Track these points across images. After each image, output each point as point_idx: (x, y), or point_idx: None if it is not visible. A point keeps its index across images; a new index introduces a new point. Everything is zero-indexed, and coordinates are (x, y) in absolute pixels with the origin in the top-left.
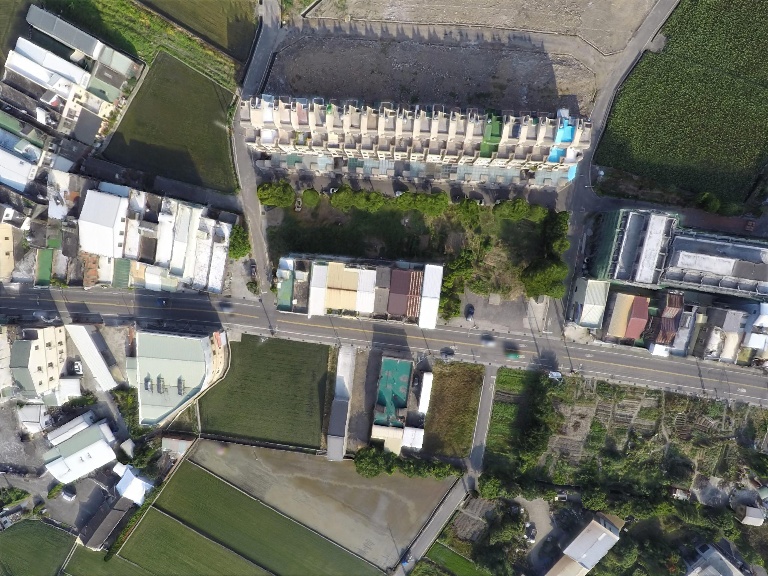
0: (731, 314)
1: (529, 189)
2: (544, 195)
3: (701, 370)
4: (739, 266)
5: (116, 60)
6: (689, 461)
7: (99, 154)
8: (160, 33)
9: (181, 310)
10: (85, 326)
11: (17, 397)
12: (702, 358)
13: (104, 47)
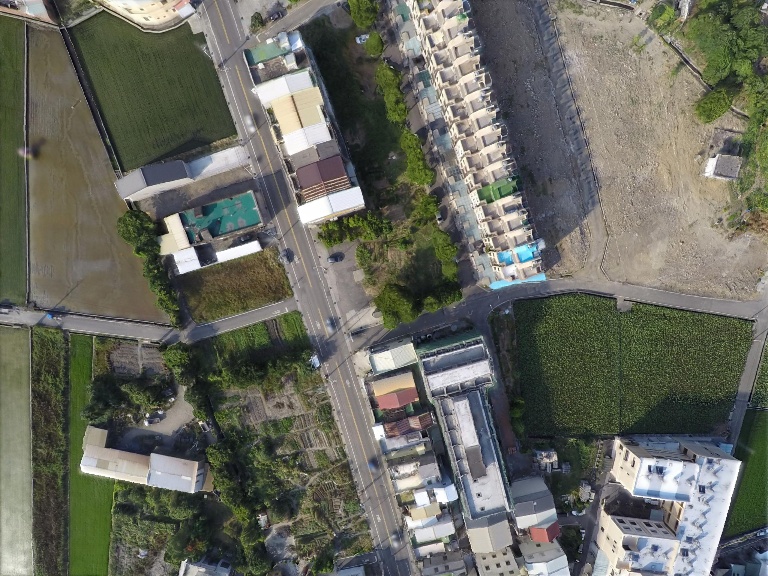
0: (434, 466)
1: (469, 258)
2: (469, 273)
3: (380, 479)
4: (475, 450)
5: None
6: (297, 512)
7: None
8: None
9: None
10: None
11: None
12: (388, 467)
13: None
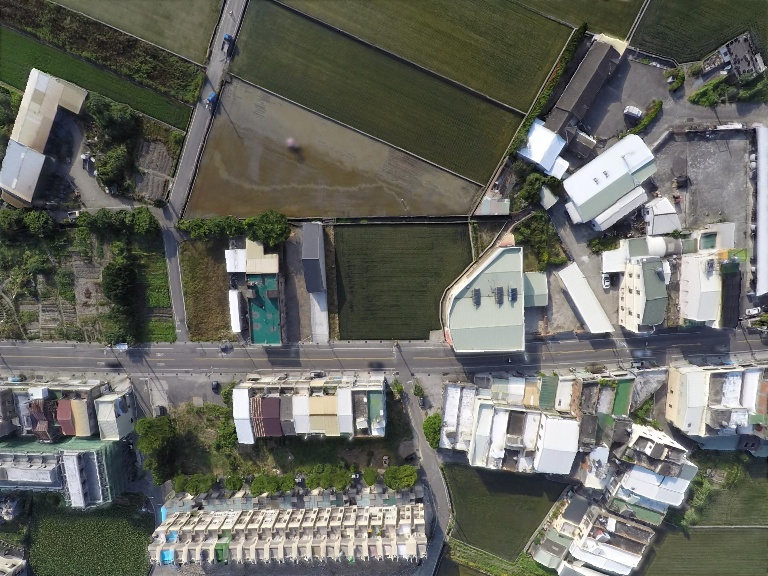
0: None
1: None
2: None
3: (4, 363)
4: (3, 476)
5: (547, 560)
6: None
7: (571, 485)
8: (514, 573)
9: (493, 355)
10: None
11: (679, 243)
12: (0, 393)
13: (557, 568)
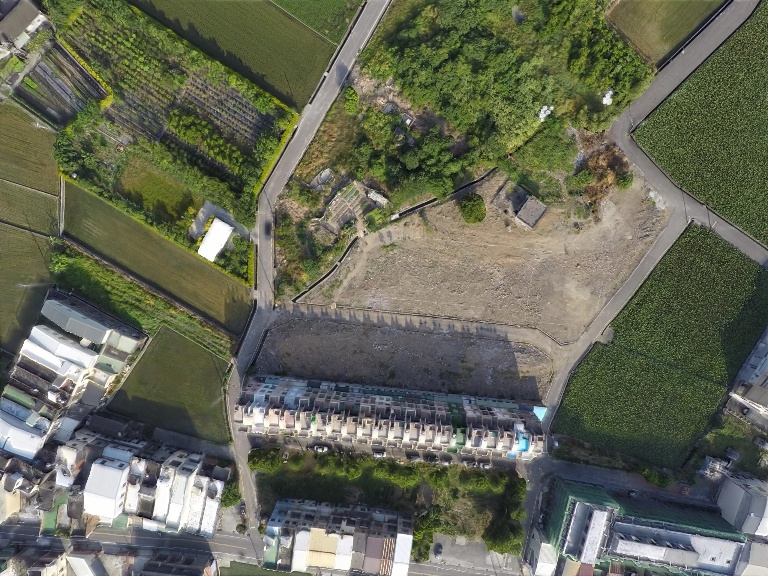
0: None
1: None
2: None
3: None
4: (669, 553)
5: (122, 342)
6: None
7: (103, 409)
8: (163, 311)
9: (175, 540)
10: (85, 558)
11: None
12: None
13: (112, 331)
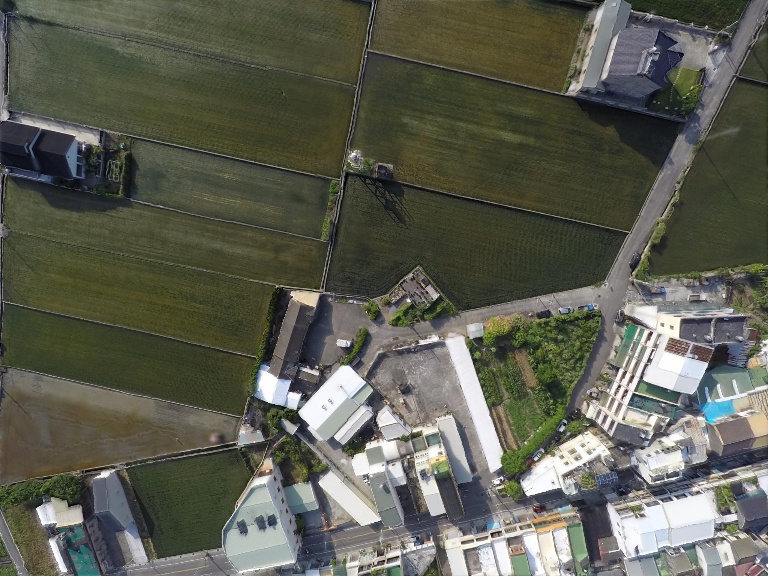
0: None
1: None
2: None
3: None
4: None
5: None
6: None
7: None
8: None
9: None
10: None
11: (408, 445)
12: None
13: None
